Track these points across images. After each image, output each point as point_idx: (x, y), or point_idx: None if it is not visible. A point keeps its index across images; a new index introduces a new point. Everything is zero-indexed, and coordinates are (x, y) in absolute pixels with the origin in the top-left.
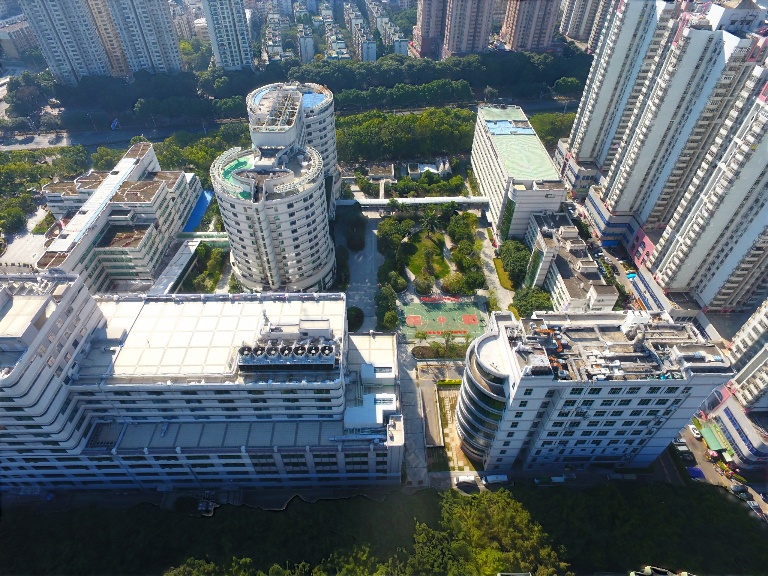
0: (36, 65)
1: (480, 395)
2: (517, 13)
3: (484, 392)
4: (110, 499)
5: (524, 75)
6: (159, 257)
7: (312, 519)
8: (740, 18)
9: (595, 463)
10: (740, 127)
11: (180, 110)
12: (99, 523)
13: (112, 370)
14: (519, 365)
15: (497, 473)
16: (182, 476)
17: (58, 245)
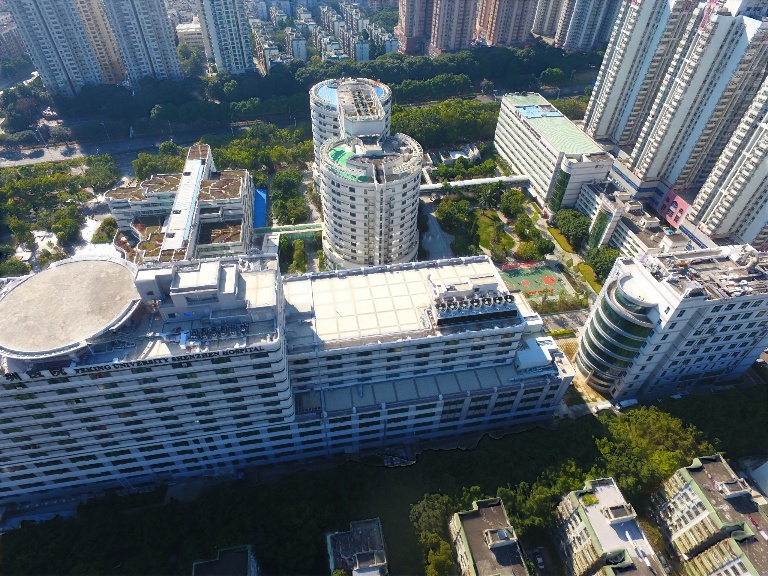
0: (10, 78)
1: (626, 327)
2: (497, 11)
3: (634, 322)
4: (294, 470)
5: (511, 68)
6: None
7: (509, 450)
8: (754, 5)
9: (702, 379)
10: None
11: (200, 114)
12: (318, 483)
13: (318, 338)
14: (675, 291)
15: (626, 399)
16: (371, 435)
17: (170, 243)
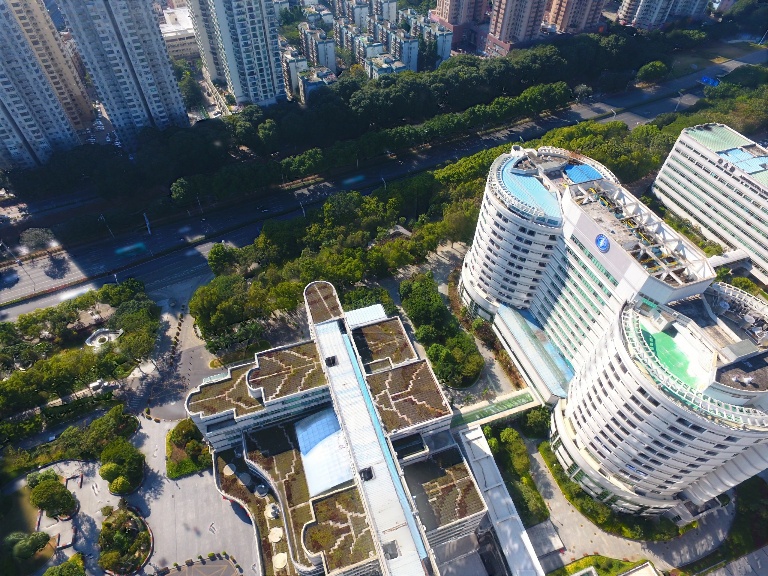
0: None
1: None
2: None
3: None
4: None
5: (599, 63)
6: None
7: None
8: None
9: None
10: None
11: (244, 185)
12: None
13: None
14: None
15: None
16: None
17: None
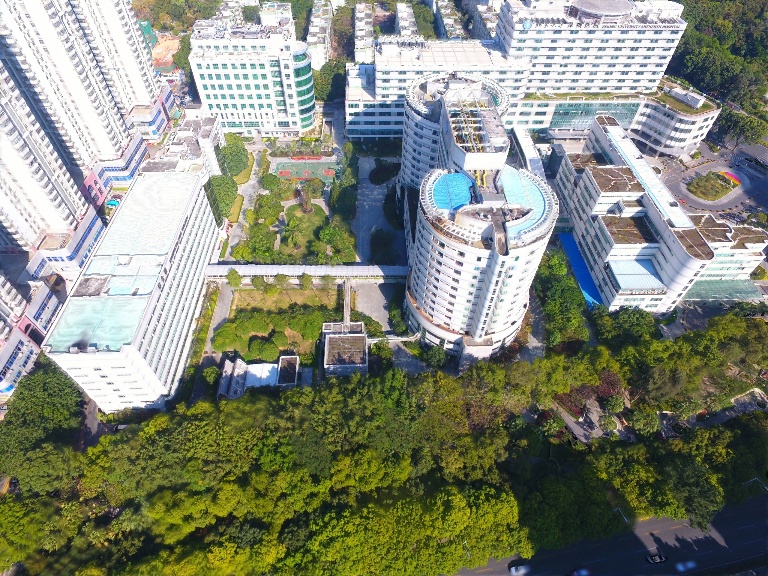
0: None
1: None
2: None
3: None
4: None
5: None
6: None
7: None
8: None
9: None
10: (54, 5)
11: None
12: None
13: None
14: None
15: None
16: None
17: (618, 130)
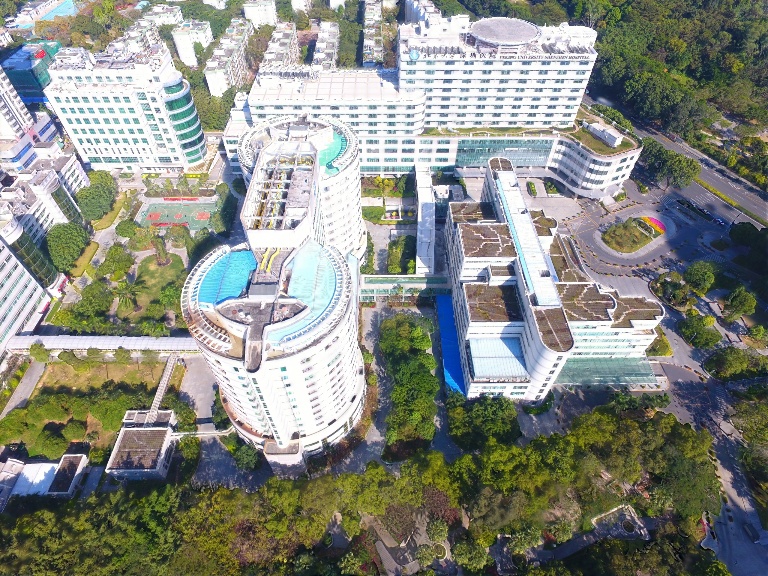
0: None
1: None
2: None
3: None
4: None
5: None
6: None
7: None
8: None
9: None
10: None
11: None
12: None
13: None
14: (166, 52)
15: None
16: None
17: (509, 176)
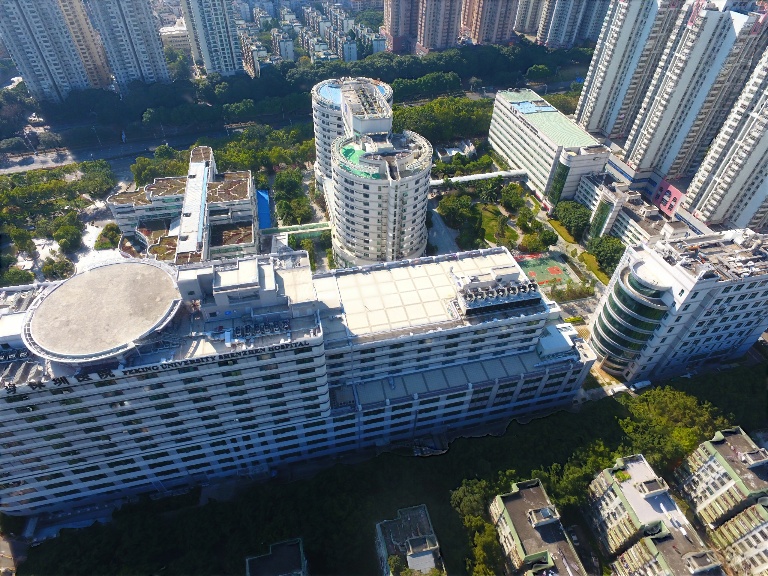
0: None
1: (641, 310)
2: (481, 10)
3: (650, 305)
4: (326, 465)
5: (498, 65)
6: (258, 253)
7: (538, 434)
8: (740, 1)
9: (709, 359)
10: None
11: (193, 117)
12: (356, 475)
13: (350, 333)
14: (689, 274)
15: (639, 381)
16: (402, 426)
17: (185, 246)
